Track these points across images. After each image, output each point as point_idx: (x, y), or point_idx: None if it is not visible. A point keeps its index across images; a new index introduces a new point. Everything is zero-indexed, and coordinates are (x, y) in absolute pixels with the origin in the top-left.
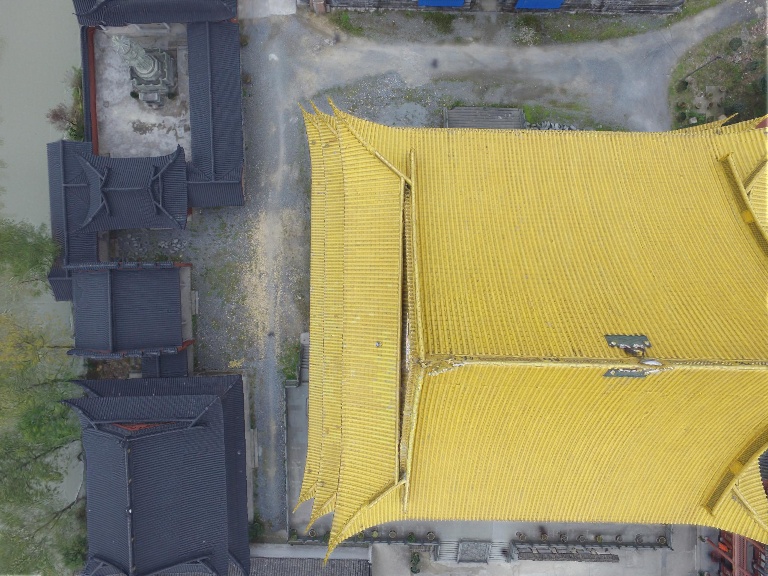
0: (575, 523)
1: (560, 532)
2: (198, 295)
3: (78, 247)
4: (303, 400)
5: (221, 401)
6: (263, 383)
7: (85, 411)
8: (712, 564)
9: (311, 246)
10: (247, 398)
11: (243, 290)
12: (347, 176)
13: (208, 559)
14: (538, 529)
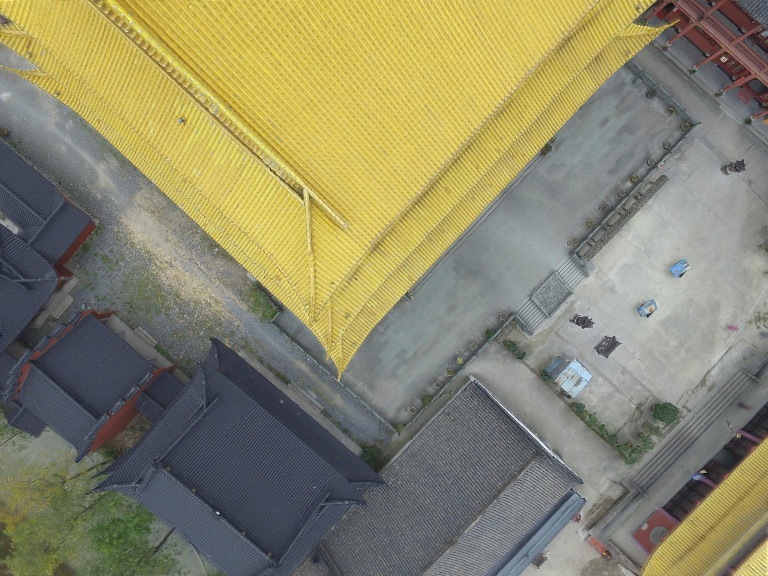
0: (604, 188)
1: (599, 207)
2: (143, 329)
3: (7, 380)
4: (297, 319)
5: (224, 375)
6: (259, 342)
7: (120, 483)
8: (749, 106)
9: (146, 175)
10: (259, 365)
11: (170, 289)
12: (17, 20)
13: (332, 497)
14: (580, 223)
